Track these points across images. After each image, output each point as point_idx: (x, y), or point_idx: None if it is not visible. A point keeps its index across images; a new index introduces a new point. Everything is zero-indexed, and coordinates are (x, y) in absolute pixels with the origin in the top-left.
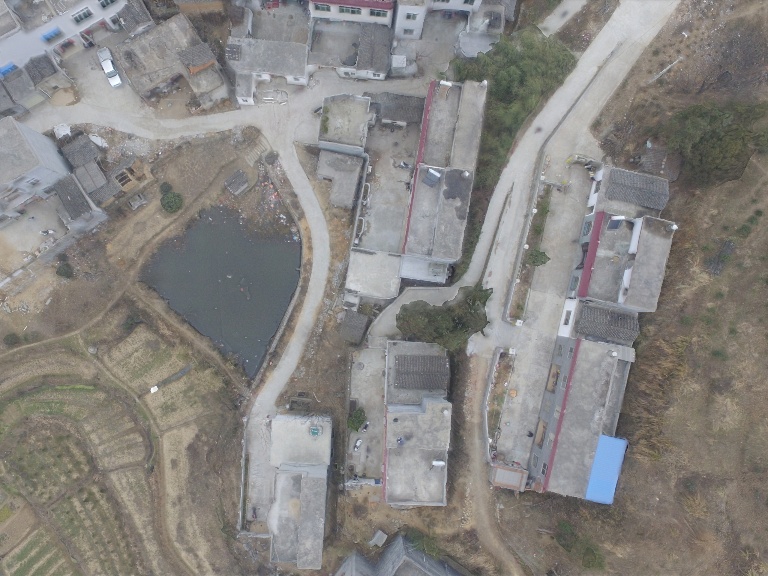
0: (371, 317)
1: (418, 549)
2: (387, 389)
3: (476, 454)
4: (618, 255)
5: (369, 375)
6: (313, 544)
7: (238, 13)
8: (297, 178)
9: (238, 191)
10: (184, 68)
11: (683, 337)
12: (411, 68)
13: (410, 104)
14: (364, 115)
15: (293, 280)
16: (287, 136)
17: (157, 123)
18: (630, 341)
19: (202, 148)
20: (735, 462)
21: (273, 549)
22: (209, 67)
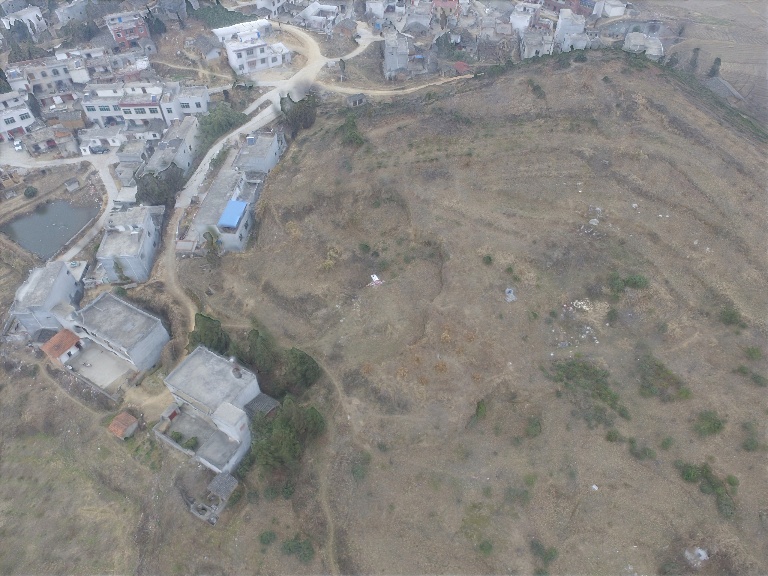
0: None
1: (117, 291)
2: None
3: (171, 246)
4: None
5: None
6: (42, 293)
7: (90, 123)
8: (107, 179)
9: (72, 187)
10: (54, 137)
11: None
12: None
13: None
14: None
15: None
16: (105, 164)
17: (35, 163)
18: None
19: (58, 174)
20: (305, 198)
21: (13, 306)
22: (67, 136)
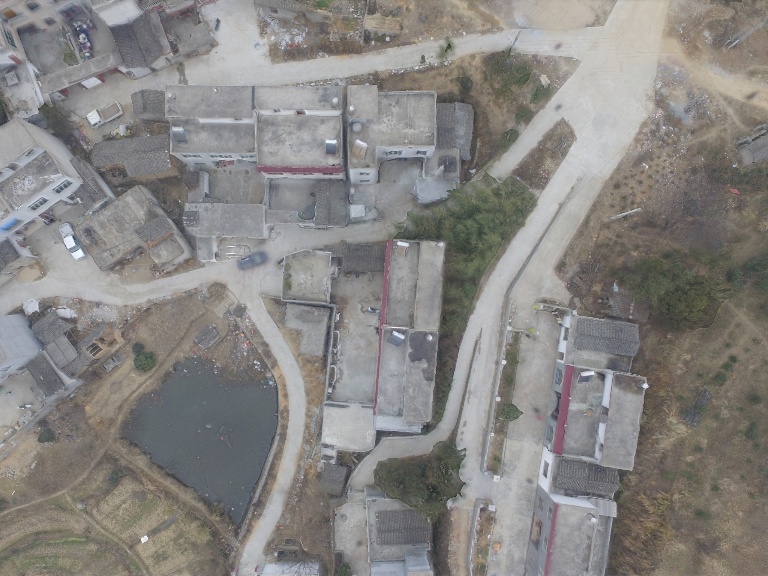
0: (351, 464)
1: None
2: (370, 547)
3: None
4: (591, 407)
5: (352, 526)
6: None
7: (193, 180)
8: (267, 328)
9: (209, 345)
10: None
11: (663, 494)
12: (371, 214)
13: (371, 255)
14: (326, 268)
15: (272, 423)
16: (253, 288)
17: (123, 289)
18: (611, 492)
19: (170, 306)
20: None
21: None
22: (168, 237)
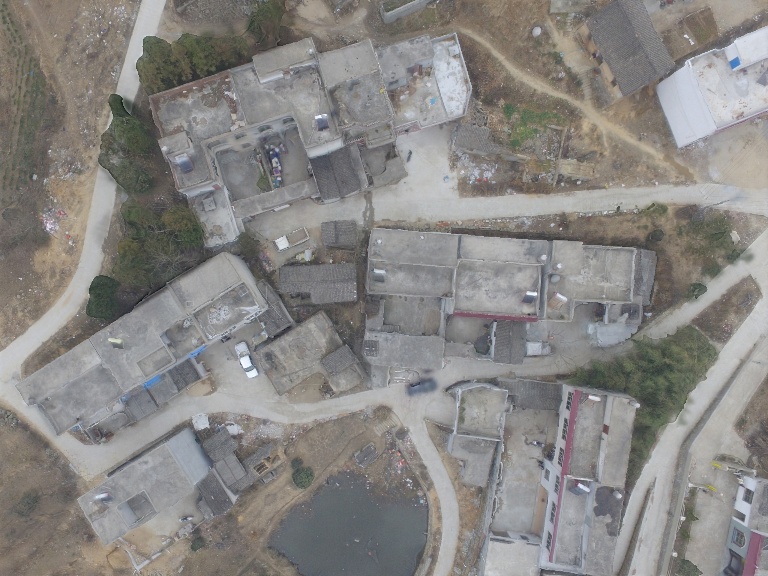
0: None
1: None
2: None
3: None
4: None
5: None
6: None
7: (375, 309)
8: (427, 451)
9: None
10: None
11: None
12: (545, 351)
13: (548, 395)
14: (500, 404)
15: (419, 540)
16: (418, 413)
17: (291, 407)
18: None
19: (332, 423)
20: None
21: None
22: (348, 367)
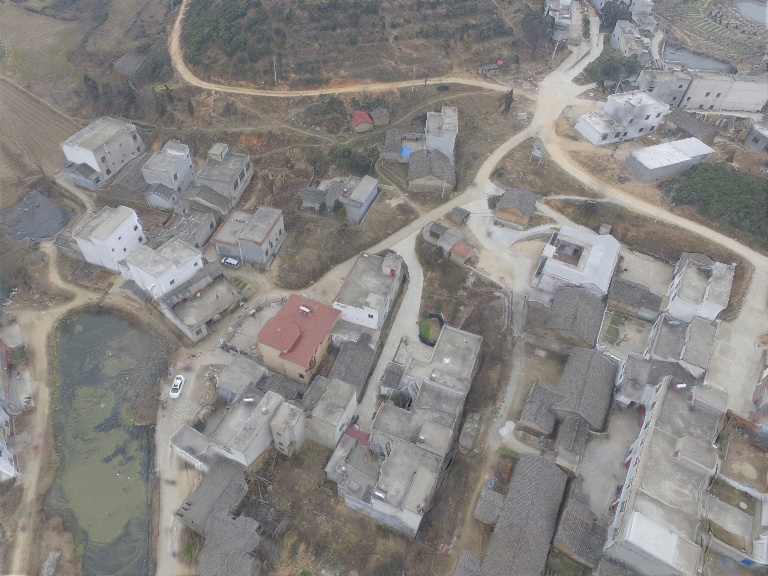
0: None
1: None
2: None
3: None
4: None
5: None
6: None
7: None
8: None
9: None
10: None
11: None
12: None
13: None
14: None
15: None
16: None
17: None
18: None
19: None
20: None
21: None
22: None
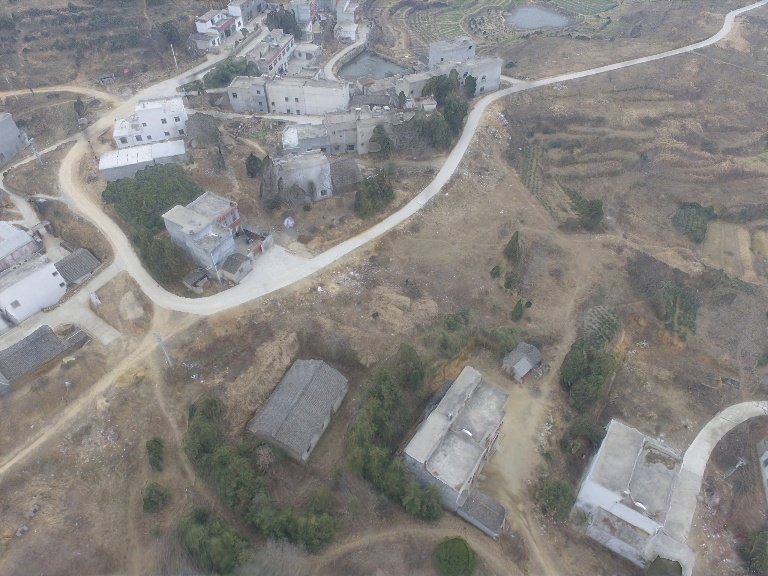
0: None
1: None
2: None
3: None
4: None
5: None
6: None
7: None
8: None
9: None
10: None
11: (205, 6)
12: None
13: None
14: None
15: None
16: None
17: None
18: None
19: None
20: None
21: (358, 2)
22: None
